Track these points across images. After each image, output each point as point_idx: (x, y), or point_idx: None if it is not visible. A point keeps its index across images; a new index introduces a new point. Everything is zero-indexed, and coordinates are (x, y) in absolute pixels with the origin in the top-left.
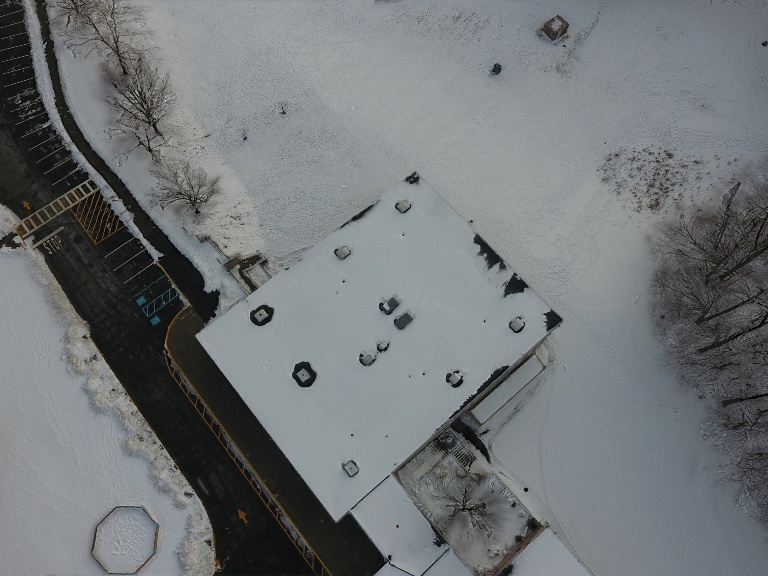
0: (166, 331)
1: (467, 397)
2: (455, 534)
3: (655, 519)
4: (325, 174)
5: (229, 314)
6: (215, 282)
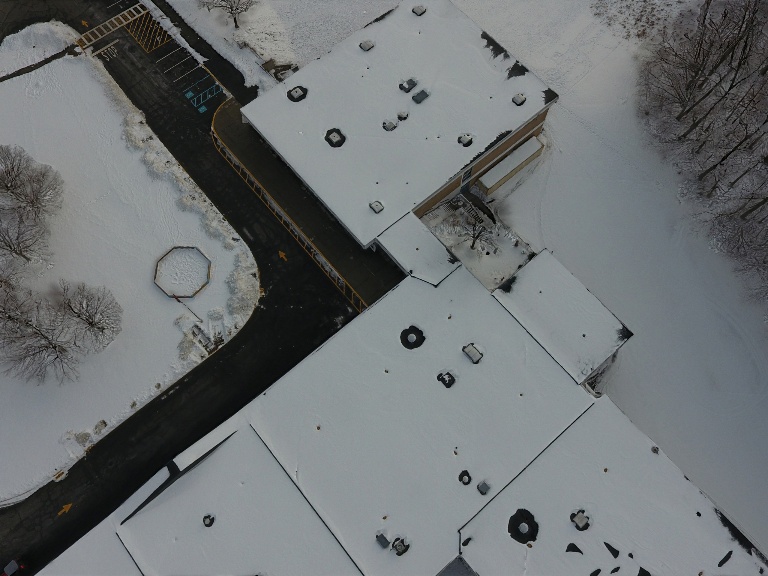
0: (212, 117)
1: (476, 154)
2: None
3: (639, 267)
4: (348, 3)
5: (269, 93)
6: (254, 79)
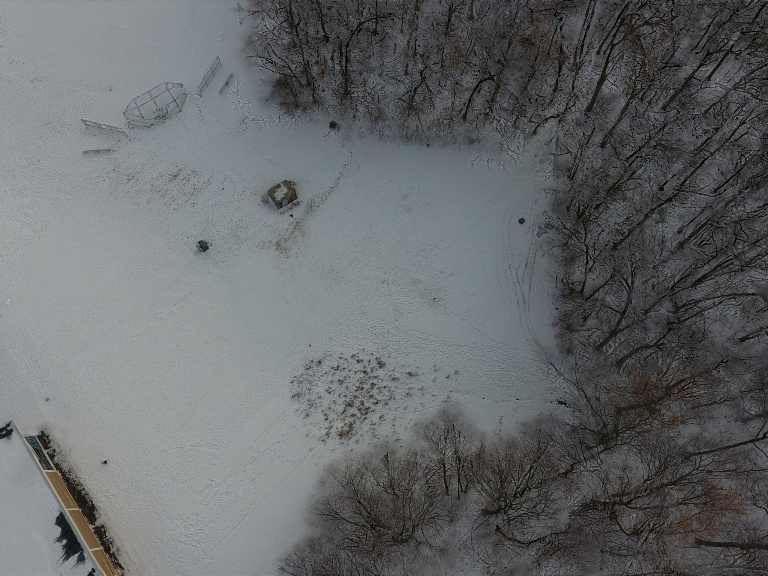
0: None
1: None
2: None
3: None
4: None
5: None
6: None
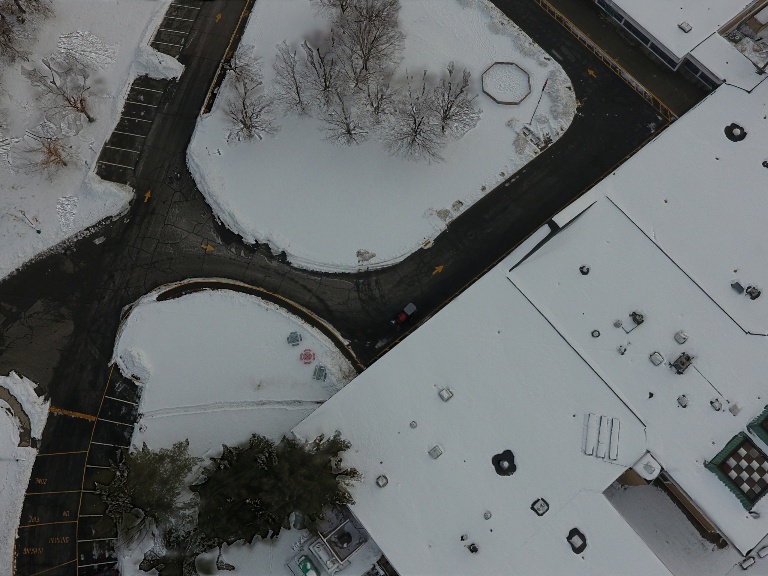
0: None
1: None
2: None
3: None
4: None
5: None
6: None
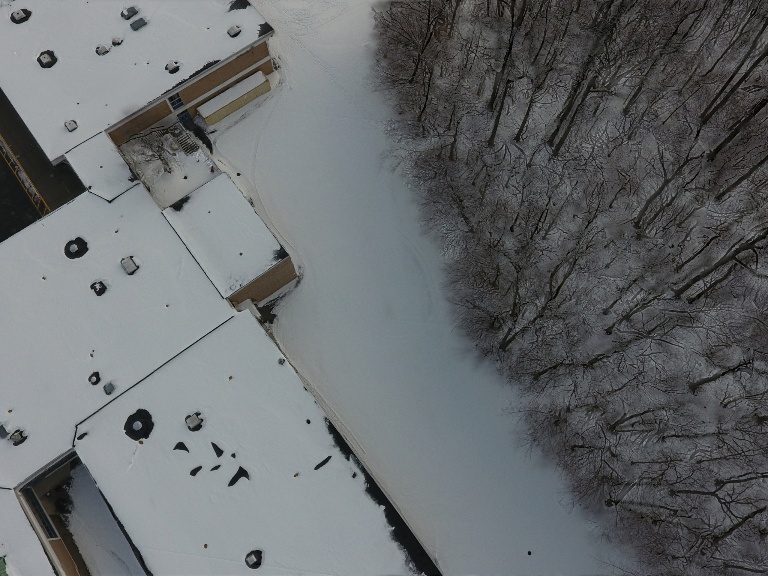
0: None
1: (180, 80)
2: (160, 189)
3: (343, 200)
4: None
5: None
6: None
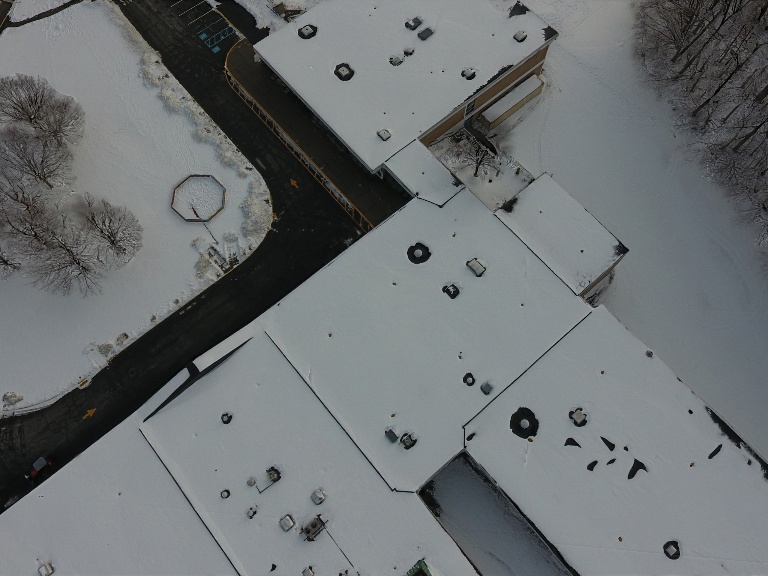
0: (225, 57)
1: (479, 86)
2: None
3: (635, 197)
4: None
5: (280, 31)
6: (265, 21)
